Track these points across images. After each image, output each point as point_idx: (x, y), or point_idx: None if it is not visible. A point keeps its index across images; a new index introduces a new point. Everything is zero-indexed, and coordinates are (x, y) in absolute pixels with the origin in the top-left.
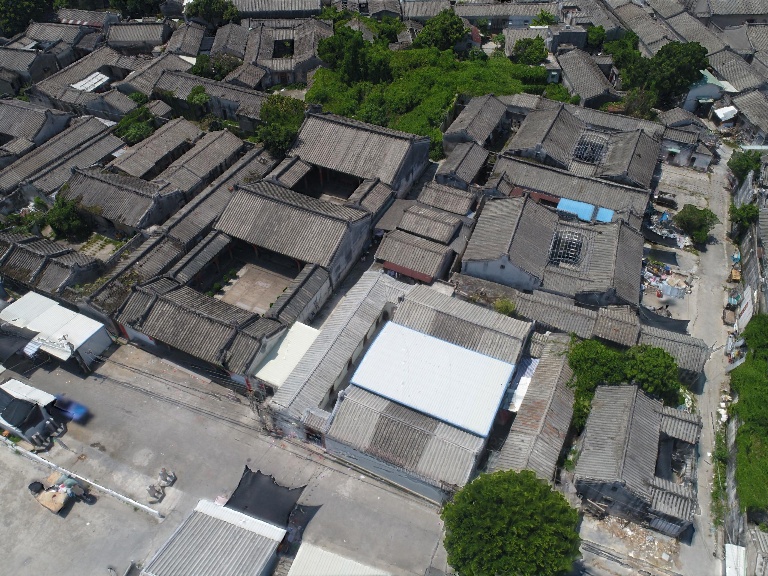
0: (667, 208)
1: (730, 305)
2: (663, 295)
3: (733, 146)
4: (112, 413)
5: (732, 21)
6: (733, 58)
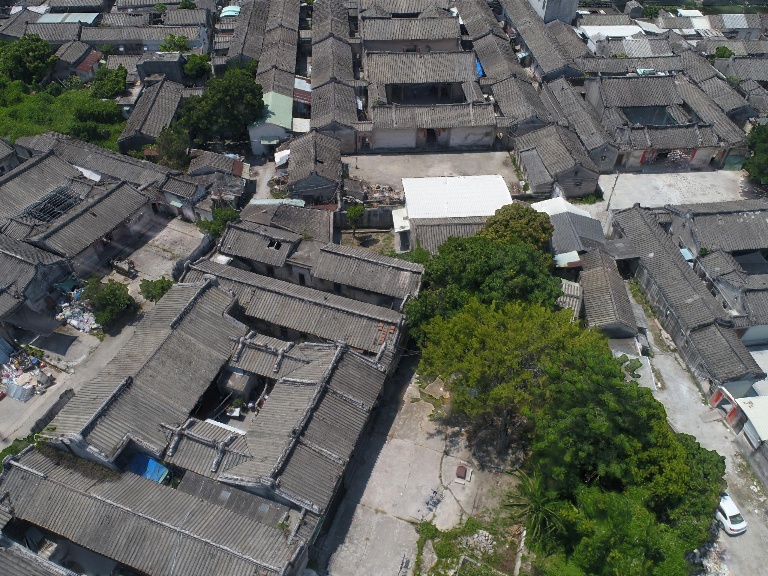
0: (124, 277)
1: None
2: (5, 397)
3: (277, 196)
4: None
5: (390, 47)
6: (331, 92)
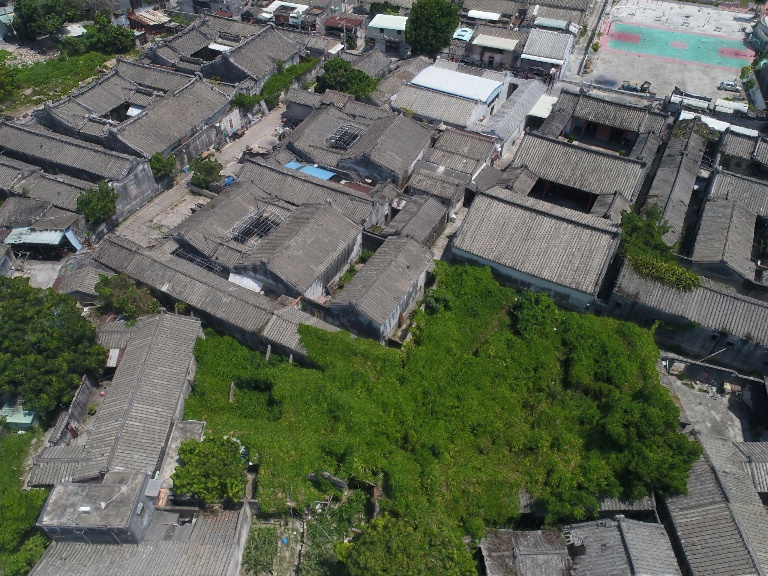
0: None
1: (233, 136)
2: None
3: None
4: None
5: None
6: None
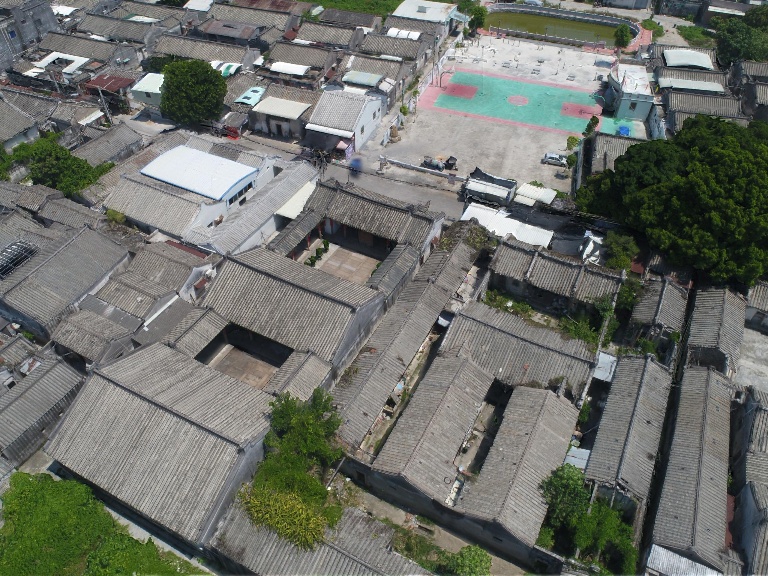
0: None
1: None
2: None
3: None
4: (431, 200)
5: None
6: None
